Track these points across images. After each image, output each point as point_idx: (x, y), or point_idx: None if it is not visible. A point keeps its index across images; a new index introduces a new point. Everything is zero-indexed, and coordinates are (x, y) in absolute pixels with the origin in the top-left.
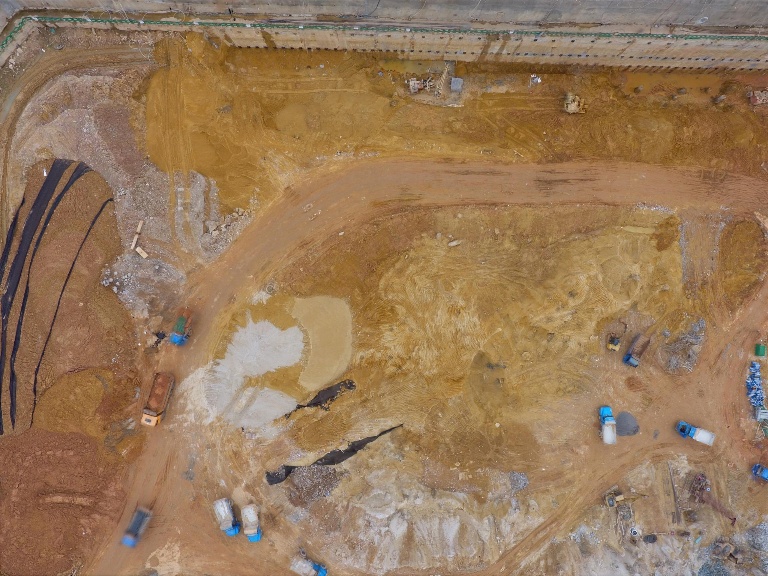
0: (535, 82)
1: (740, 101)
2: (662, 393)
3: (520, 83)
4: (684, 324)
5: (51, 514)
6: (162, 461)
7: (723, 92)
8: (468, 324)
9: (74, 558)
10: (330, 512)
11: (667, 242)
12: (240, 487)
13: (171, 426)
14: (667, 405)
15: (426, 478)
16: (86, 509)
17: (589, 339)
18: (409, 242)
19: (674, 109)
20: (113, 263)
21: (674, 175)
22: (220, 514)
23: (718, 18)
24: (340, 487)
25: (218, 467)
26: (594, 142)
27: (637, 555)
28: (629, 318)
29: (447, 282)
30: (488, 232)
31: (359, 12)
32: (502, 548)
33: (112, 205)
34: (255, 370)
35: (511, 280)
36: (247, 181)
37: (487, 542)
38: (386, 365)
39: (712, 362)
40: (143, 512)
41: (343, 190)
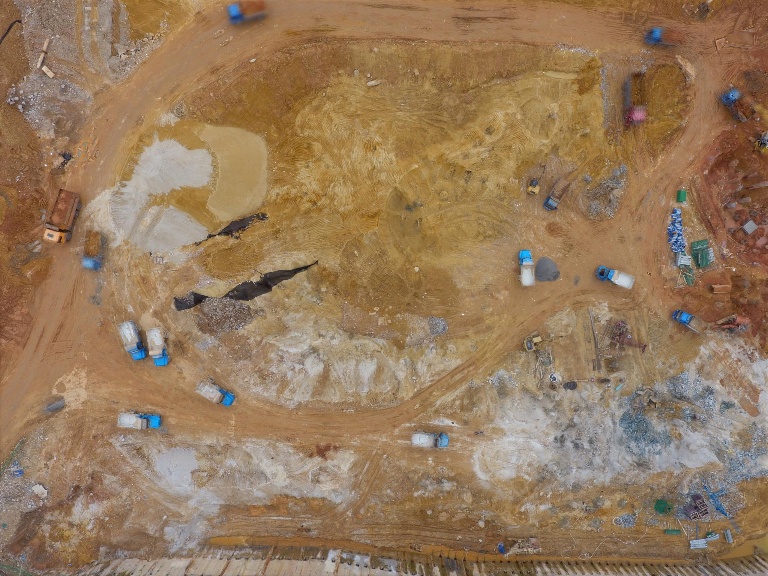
0: None
1: None
2: (583, 239)
3: None
4: (606, 170)
5: None
6: (69, 285)
7: None
8: (384, 160)
9: None
10: (241, 343)
11: (588, 85)
12: (148, 313)
13: (78, 249)
14: (588, 251)
15: (345, 323)
16: None
17: (508, 181)
18: (326, 79)
19: None
20: (20, 83)
21: (595, 16)
22: (126, 337)
23: None
24: (254, 323)
25: (126, 292)
26: None
27: (554, 397)
28: (550, 163)
29: (365, 122)
30: (407, 73)
31: None
32: (417, 386)
33: (20, 26)
34: (160, 187)
35: (431, 123)
36: (157, 5)
37: (402, 380)
38: (301, 201)
39: (633, 208)
40: (50, 337)
41: (255, 17)
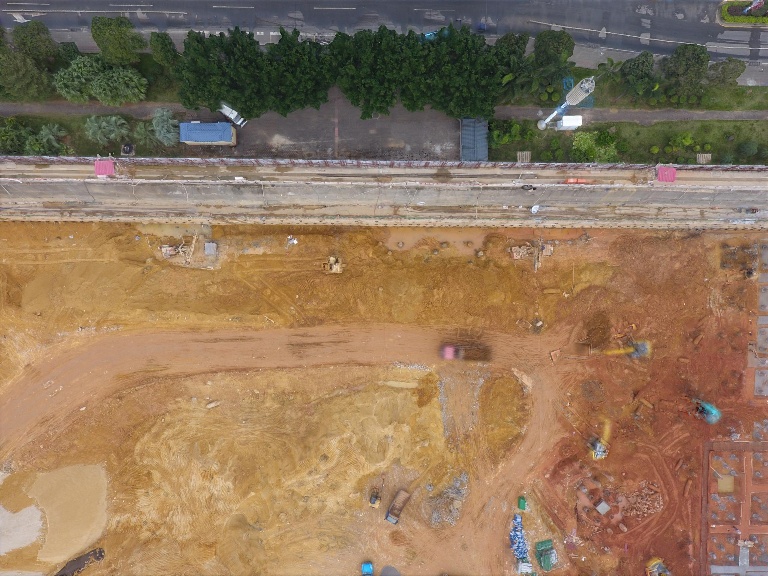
0: (291, 243)
1: (502, 254)
2: (426, 547)
3: (277, 244)
4: (448, 477)
5: None
6: None
7: (485, 246)
8: (221, 488)
9: None
10: None
11: (426, 399)
12: None
13: None
14: (431, 559)
15: None
16: None
17: (349, 497)
18: (164, 407)
19: (435, 265)
20: None
21: (430, 334)
22: None
23: (435, 202)
24: None
25: None
26: (348, 304)
27: None
28: (392, 473)
29: (206, 443)
30: (247, 392)
31: (82, 200)
32: None
33: None
34: None
35: (273, 438)
36: None
37: None
38: (141, 530)
39: (475, 515)
40: None
41: (85, 365)
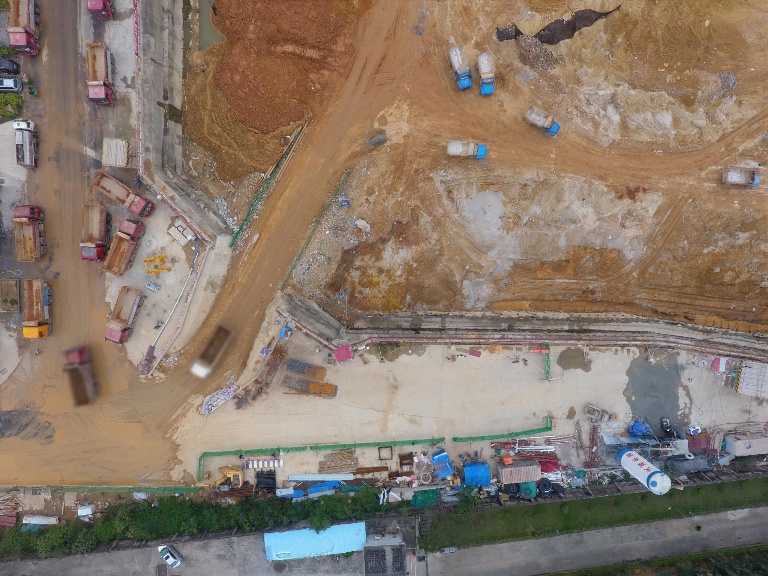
0: None
1: None
2: None
3: None
4: None
5: (283, 61)
6: (392, 15)
7: None
8: None
9: (305, 110)
10: (555, 81)
11: None
12: (469, 44)
13: None
14: None
15: (633, 80)
16: (315, 63)
17: None
18: None
19: None
20: None
21: None
22: (453, 64)
23: None
24: (558, 69)
25: (448, 23)
26: None
27: None
28: None
29: None
30: None
31: None
32: (720, 132)
33: None
34: None
35: None
36: None
37: (705, 126)
38: None
39: None
40: (372, 69)
41: None
